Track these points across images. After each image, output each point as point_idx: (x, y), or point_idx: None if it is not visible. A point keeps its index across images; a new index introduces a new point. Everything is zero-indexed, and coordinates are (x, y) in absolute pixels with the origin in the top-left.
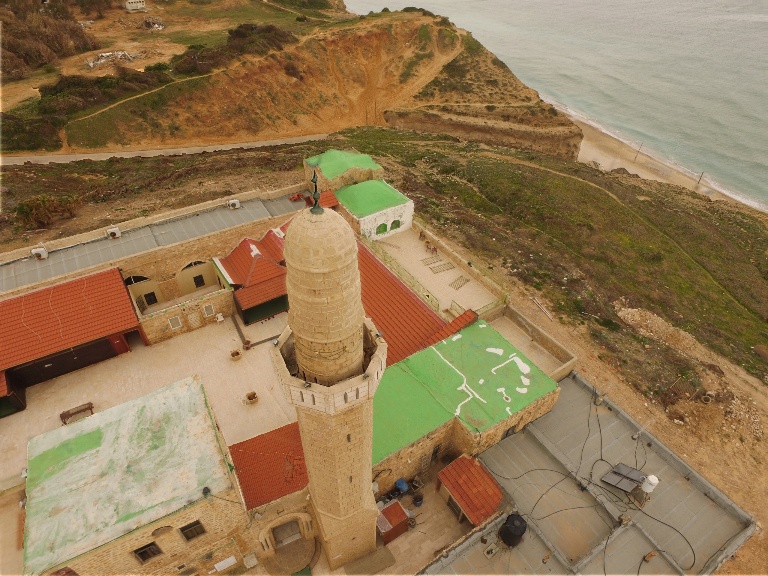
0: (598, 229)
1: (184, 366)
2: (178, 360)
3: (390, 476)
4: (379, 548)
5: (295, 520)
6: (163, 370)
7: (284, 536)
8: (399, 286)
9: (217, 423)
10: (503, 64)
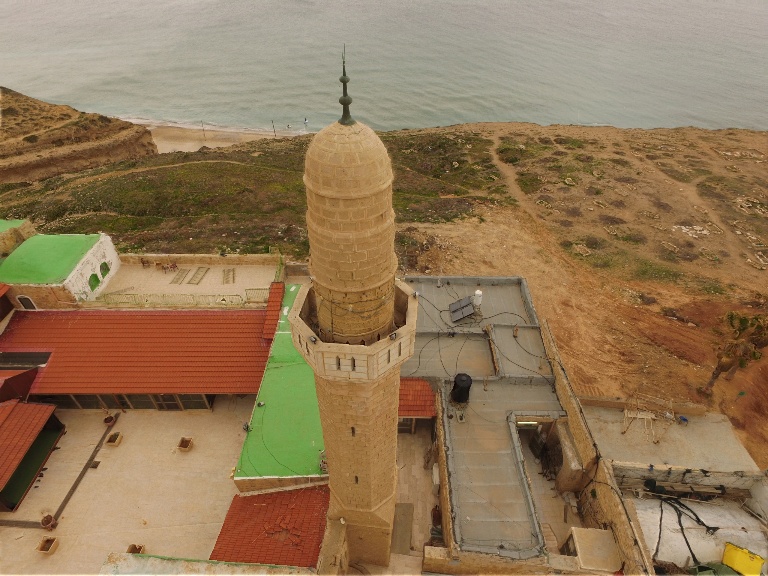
0: (254, 189)
1: None
2: None
3: None
4: None
5: None
6: None
7: None
8: (181, 315)
9: None
10: (3, 89)
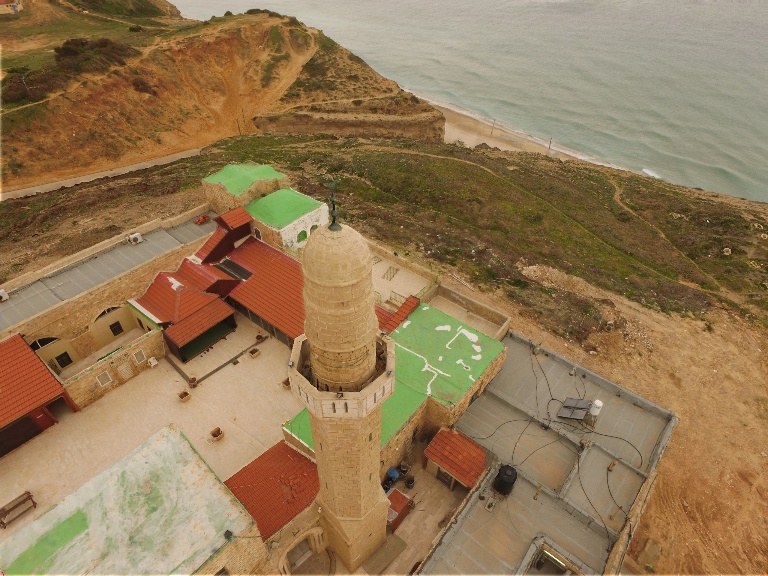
0: (485, 202)
1: (128, 422)
2: (119, 418)
3: (382, 468)
4: (388, 538)
5: (306, 538)
6: (105, 433)
7: (295, 558)
8: None
9: None
10: (359, 59)
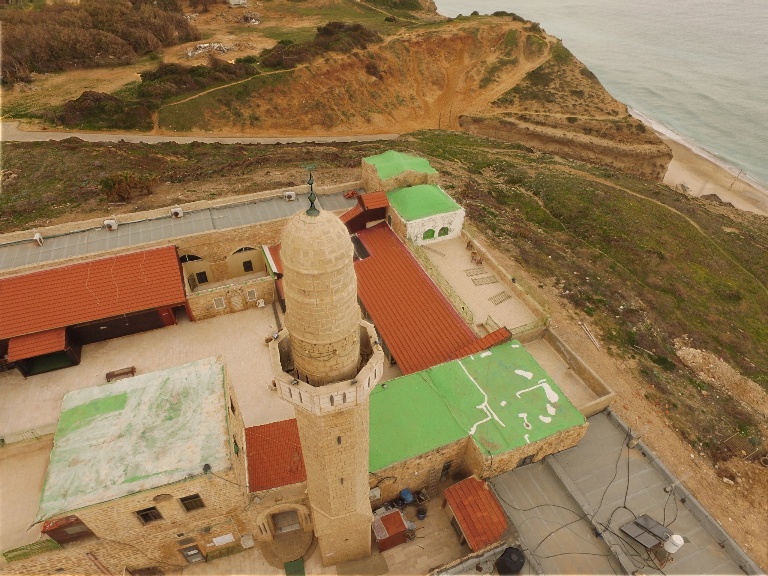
0: (670, 258)
1: (221, 345)
2: (217, 339)
3: (395, 484)
4: (374, 554)
5: (295, 510)
6: (202, 346)
7: (284, 524)
8: (436, 294)
9: (235, 404)
10: (592, 74)
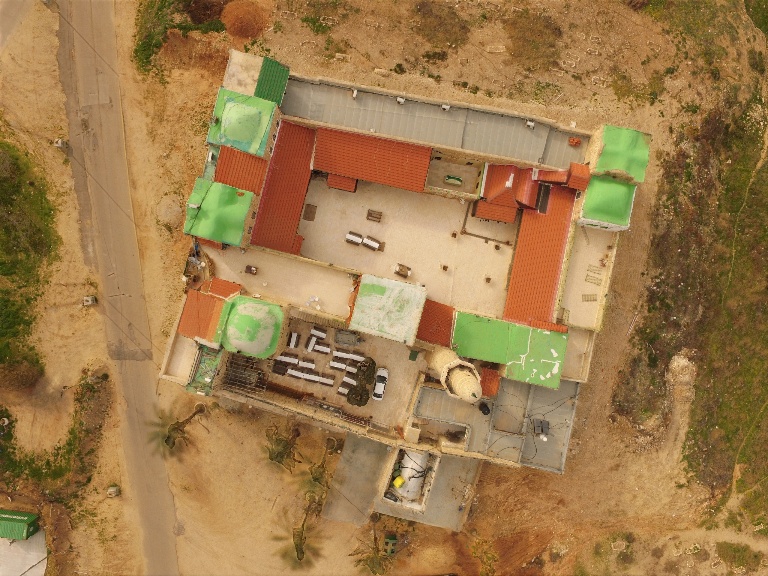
0: None
1: (429, 221)
2: (428, 214)
3: None
4: None
5: None
6: (419, 216)
7: None
8: (557, 276)
9: None
10: None
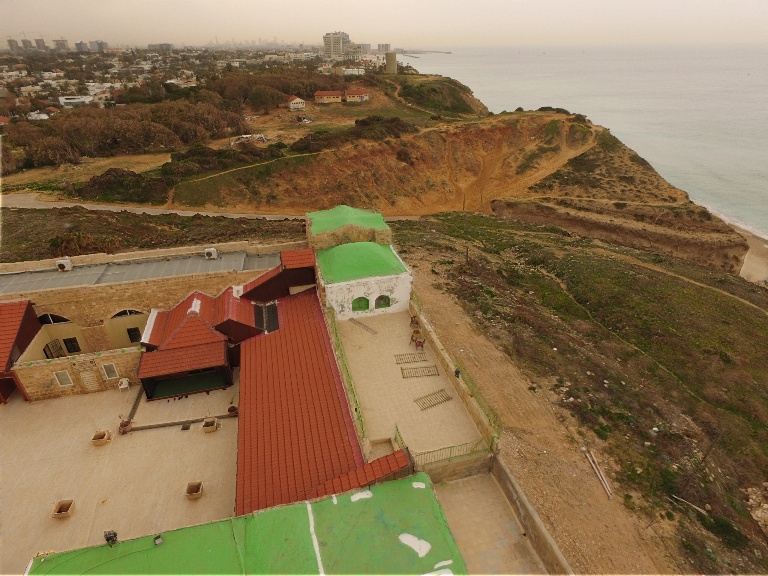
0: (741, 363)
1: (38, 438)
2: (40, 428)
3: None
4: None
5: None
6: (13, 437)
7: None
8: (335, 386)
9: None
10: (644, 161)
